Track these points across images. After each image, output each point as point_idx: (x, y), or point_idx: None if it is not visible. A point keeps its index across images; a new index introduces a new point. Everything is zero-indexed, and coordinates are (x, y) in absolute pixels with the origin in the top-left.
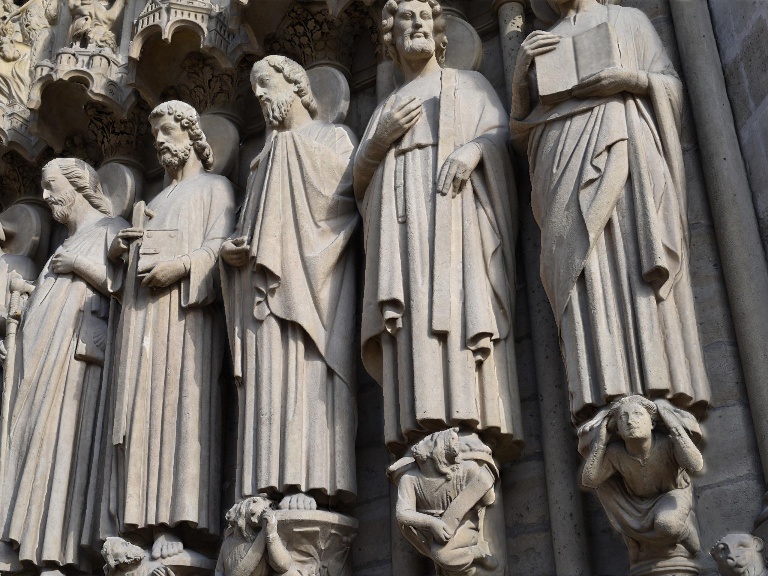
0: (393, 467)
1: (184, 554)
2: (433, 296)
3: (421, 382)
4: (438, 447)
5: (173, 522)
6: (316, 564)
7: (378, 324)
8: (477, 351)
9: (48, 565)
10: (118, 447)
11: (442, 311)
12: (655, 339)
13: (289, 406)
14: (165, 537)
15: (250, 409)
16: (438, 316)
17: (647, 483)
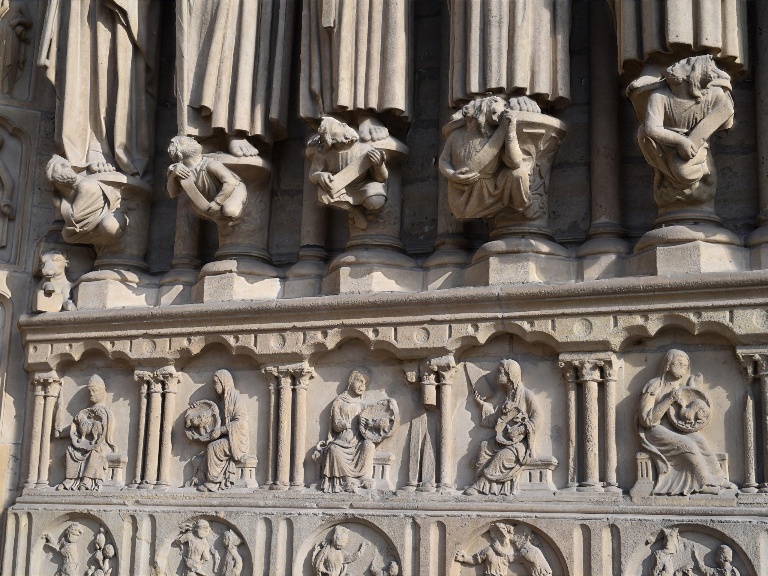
0: (637, 84)
1: (390, 139)
2: None
3: (674, 6)
4: (696, 72)
5: (382, 108)
6: (532, 162)
7: None
8: None
9: (238, 134)
10: (322, 29)
11: None
12: None
13: (518, 11)
14: (371, 121)
15: (476, 9)
16: None
17: None
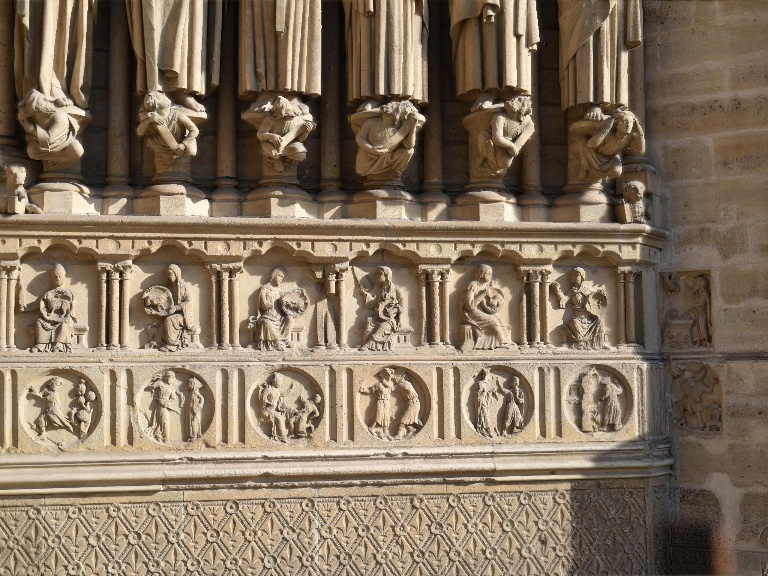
0: (485, 106)
1: None
2: (519, 11)
3: (510, 63)
4: (525, 107)
5: (308, 92)
6: None
7: (474, 12)
8: (531, 50)
9: (191, 93)
10: (268, 29)
11: (523, 22)
12: (625, 77)
13: (409, 44)
14: (297, 99)
15: (383, 38)
16: (521, 25)
17: (614, 151)
